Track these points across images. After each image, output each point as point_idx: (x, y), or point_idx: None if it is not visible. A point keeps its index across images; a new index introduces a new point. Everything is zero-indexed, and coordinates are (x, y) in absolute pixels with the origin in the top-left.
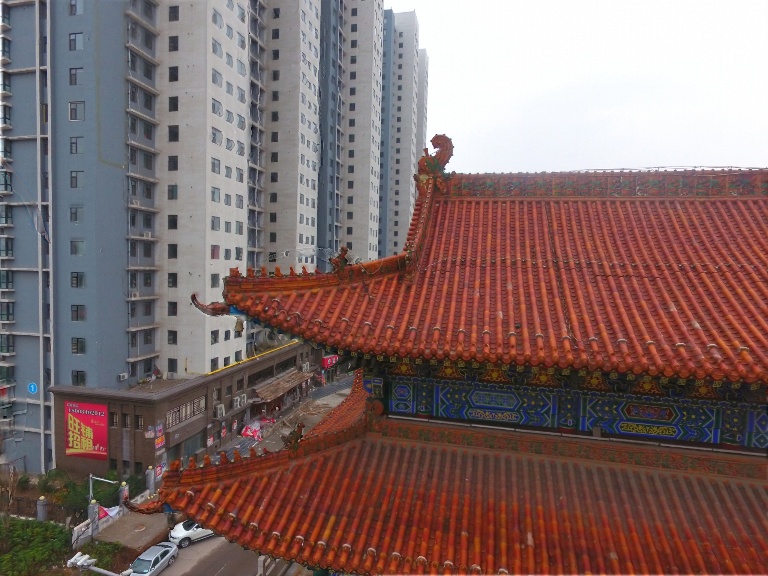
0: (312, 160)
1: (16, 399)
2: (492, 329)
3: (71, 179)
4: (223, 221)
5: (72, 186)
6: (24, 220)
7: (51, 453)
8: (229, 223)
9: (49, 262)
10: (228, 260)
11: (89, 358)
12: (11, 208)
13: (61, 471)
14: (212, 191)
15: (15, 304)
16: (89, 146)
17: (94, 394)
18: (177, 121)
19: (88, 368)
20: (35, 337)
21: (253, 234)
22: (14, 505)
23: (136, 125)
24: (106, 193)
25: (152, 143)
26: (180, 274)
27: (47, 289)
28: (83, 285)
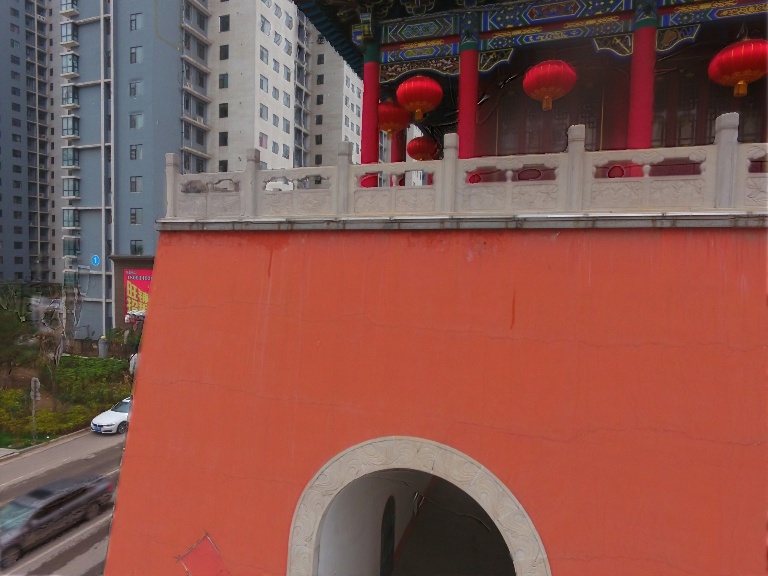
0: (357, 86)
1: (81, 253)
2: None
3: (131, 55)
4: (271, 113)
5: (132, 62)
6: (89, 100)
7: (111, 321)
8: (277, 117)
9: (111, 135)
10: (275, 154)
11: (146, 227)
12: (77, 89)
13: (120, 329)
14: (261, 79)
15: (80, 182)
16: (147, 20)
17: (150, 257)
18: (228, 10)
19: (145, 237)
20: (98, 211)
21: (299, 154)
22: (78, 346)
23: (190, 11)
24: (162, 69)
25: (205, 34)
26: (230, 161)
27: (109, 163)
28: (141, 156)
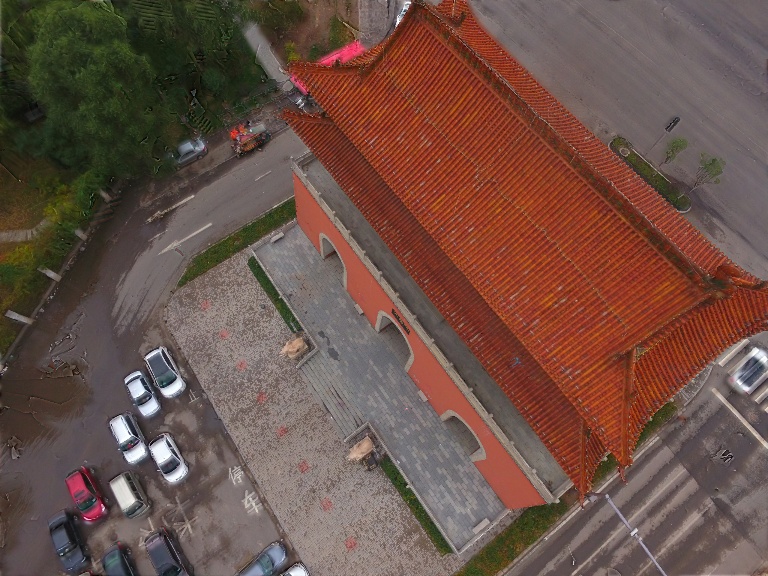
0: None
1: None
2: (691, 234)
3: None
4: None
5: None
6: None
7: None
8: None
9: None
10: None
11: None
12: None
13: None
14: None
15: None
16: None
17: None
18: None
19: None
20: None
21: None
22: None
23: None
24: None
25: None
26: None
27: None
28: None
